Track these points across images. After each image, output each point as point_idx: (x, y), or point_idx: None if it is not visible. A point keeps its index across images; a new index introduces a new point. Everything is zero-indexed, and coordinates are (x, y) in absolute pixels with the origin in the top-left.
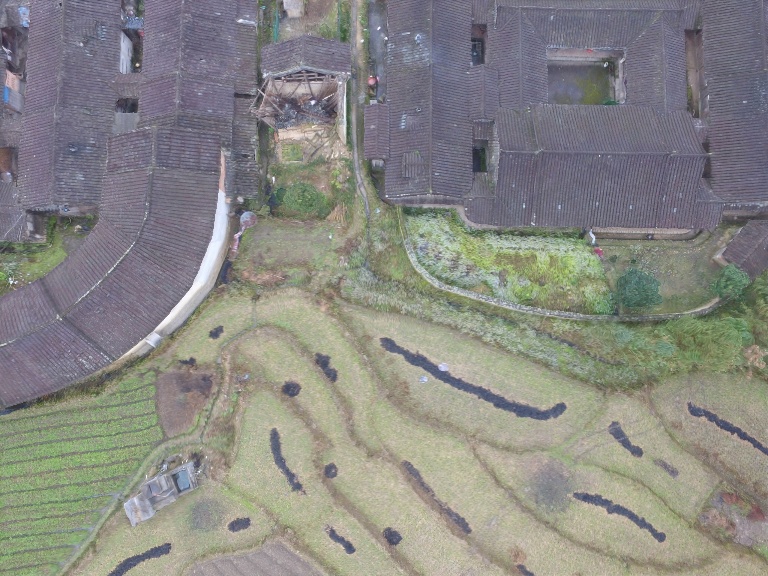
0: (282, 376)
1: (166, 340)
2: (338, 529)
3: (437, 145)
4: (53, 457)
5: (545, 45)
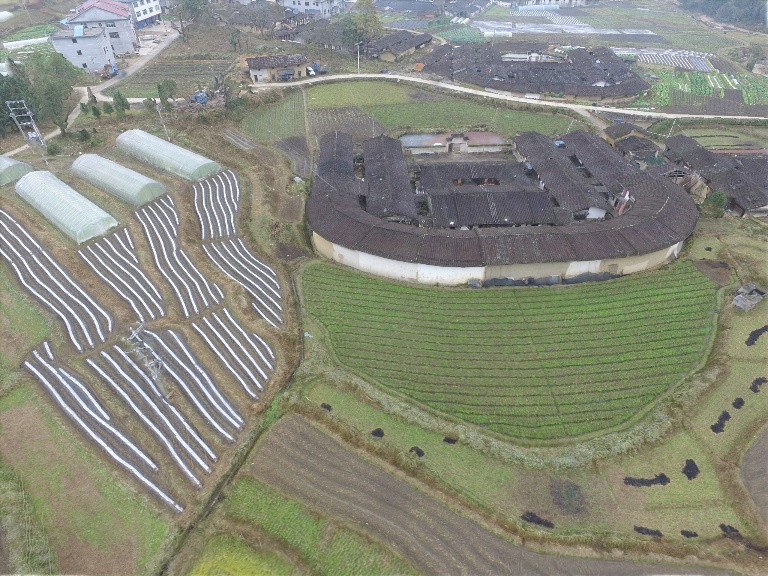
0: (765, 260)
1: (683, 252)
2: None
3: (760, 190)
4: (659, 295)
5: None
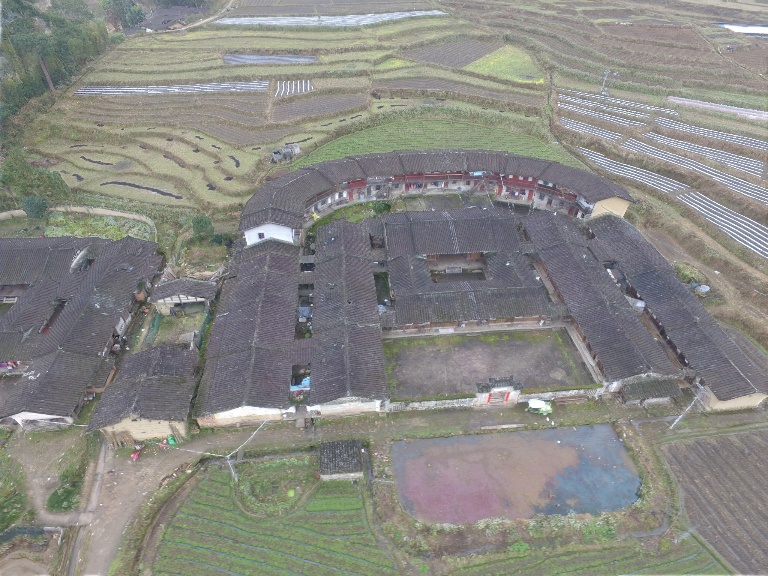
0: None
1: None
2: (217, 149)
3: None
4: None
5: (2, 320)
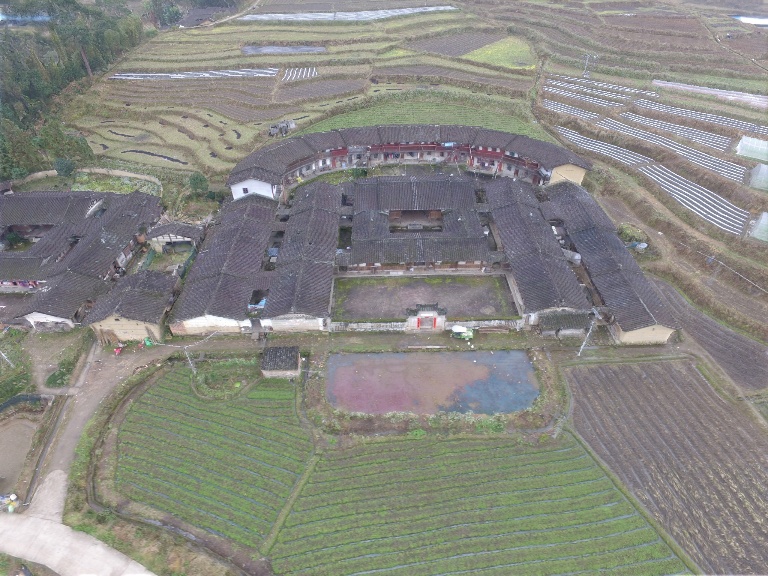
0: None
1: None
2: (223, 124)
3: None
4: None
5: None
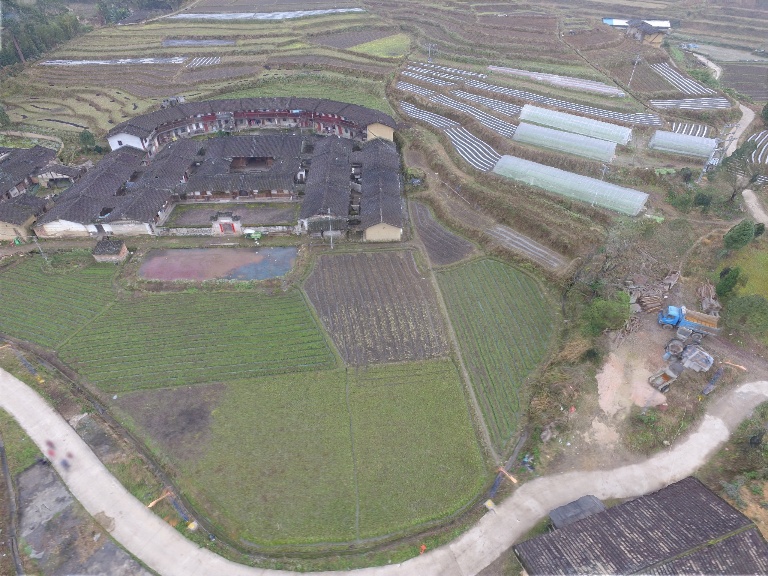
0: None
1: None
2: None
3: None
4: None
5: None
